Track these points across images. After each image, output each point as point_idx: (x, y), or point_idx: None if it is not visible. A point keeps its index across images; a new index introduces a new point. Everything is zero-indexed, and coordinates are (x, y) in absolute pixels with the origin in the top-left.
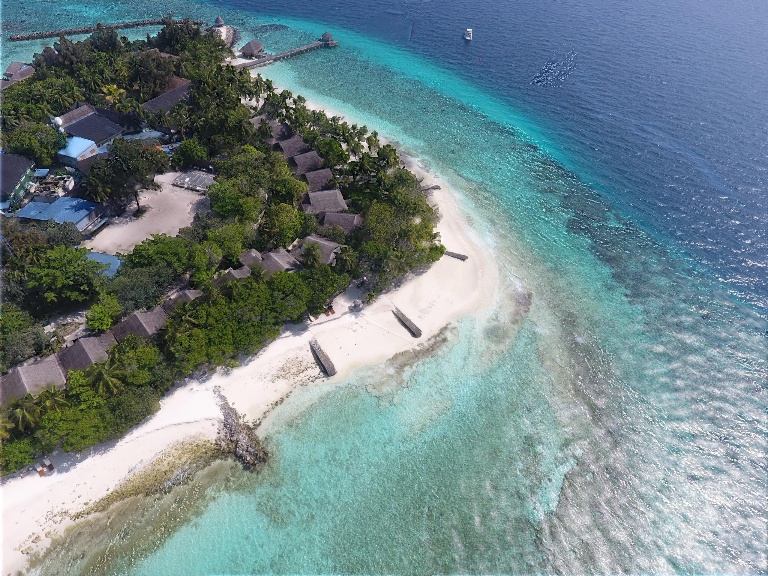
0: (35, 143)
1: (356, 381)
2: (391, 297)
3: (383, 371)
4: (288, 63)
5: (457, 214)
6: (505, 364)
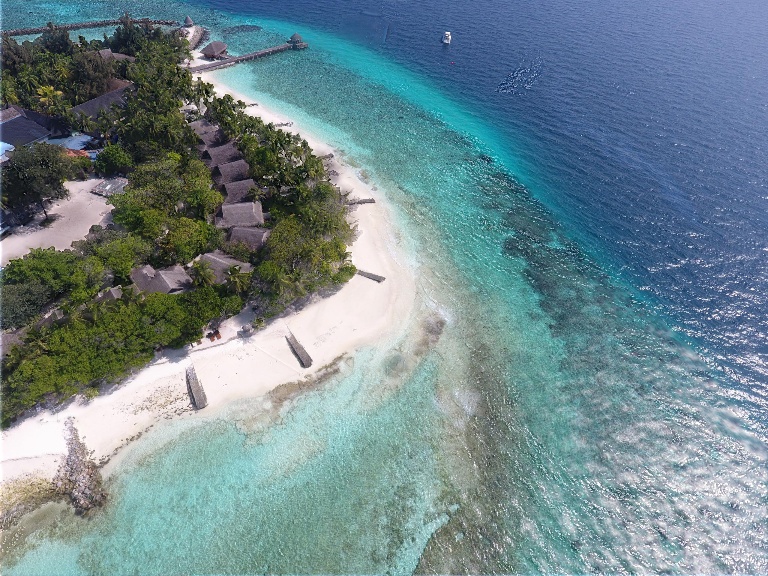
0: None
1: (227, 415)
2: (289, 321)
3: (259, 405)
4: (251, 65)
5: (386, 230)
6: (396, 401)
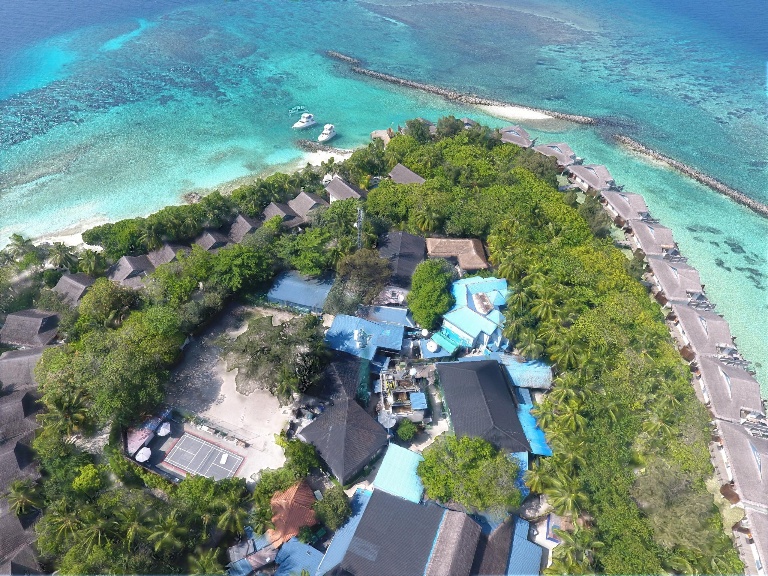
0: (449, 437)
1: (114, 223)
2: None
3: (91, 226)
4: None
5: None
6: None
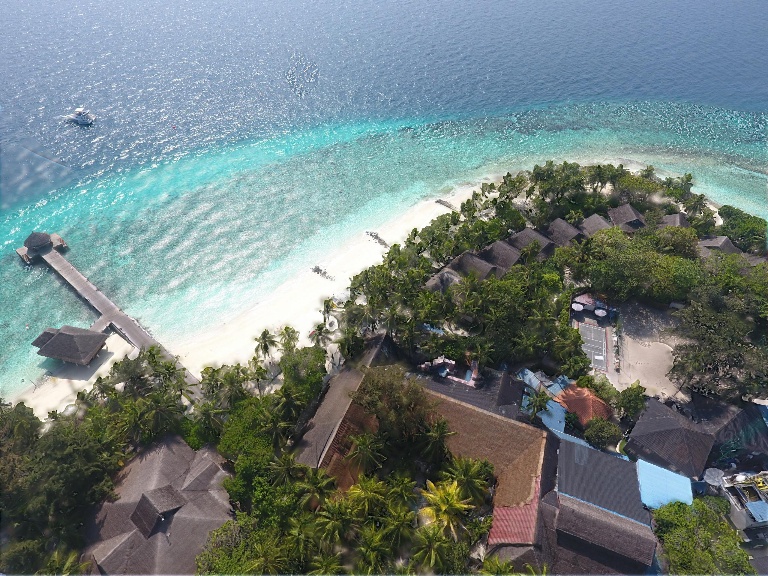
0: None
1: None
2: None
3: None
4: (135, 299)
5: None
6: None
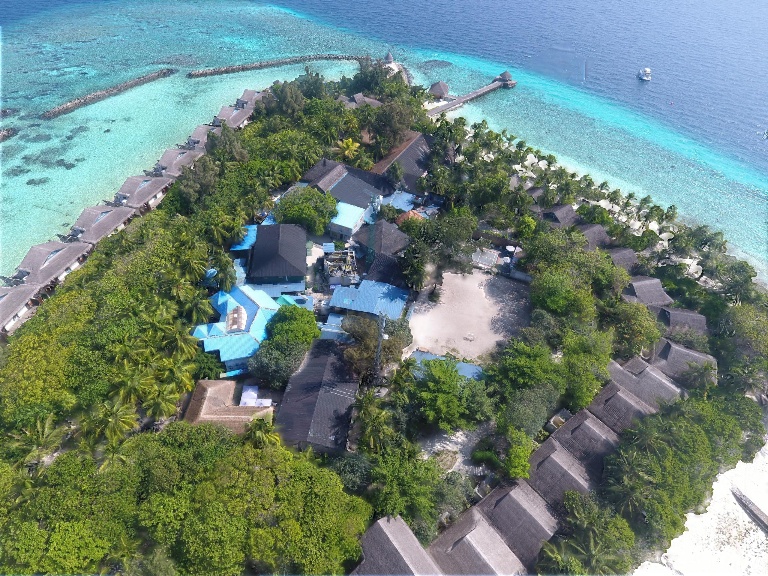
0: (315, 213)
1: None
2: None
3: None
4: (477, 106)
5: None
6: None
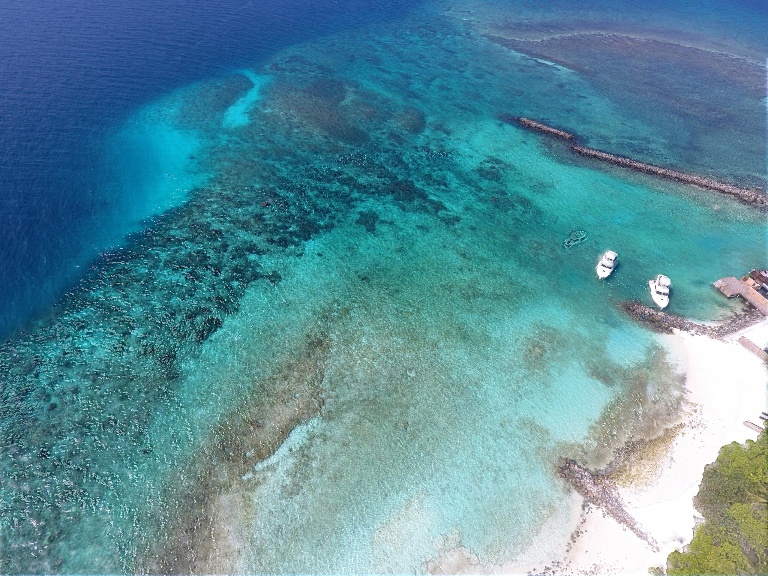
0: None
1: (493, 571)
2: None
3: None
4: None
5: None
6: None
